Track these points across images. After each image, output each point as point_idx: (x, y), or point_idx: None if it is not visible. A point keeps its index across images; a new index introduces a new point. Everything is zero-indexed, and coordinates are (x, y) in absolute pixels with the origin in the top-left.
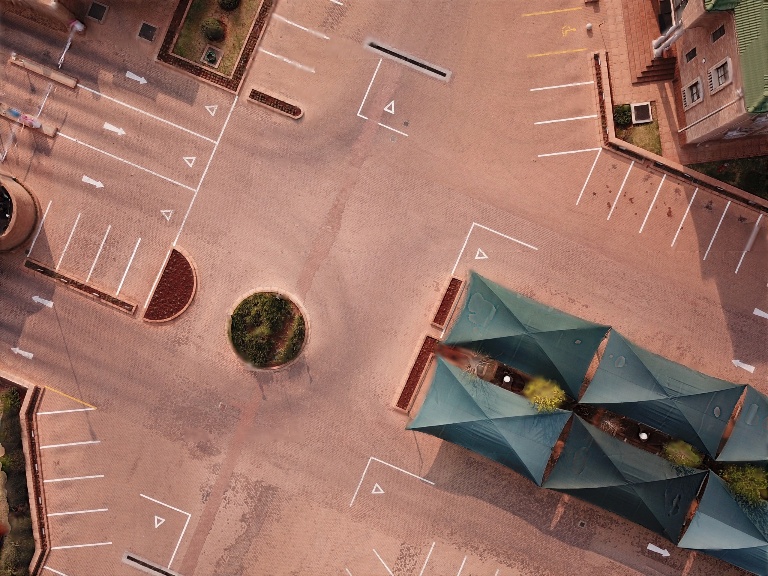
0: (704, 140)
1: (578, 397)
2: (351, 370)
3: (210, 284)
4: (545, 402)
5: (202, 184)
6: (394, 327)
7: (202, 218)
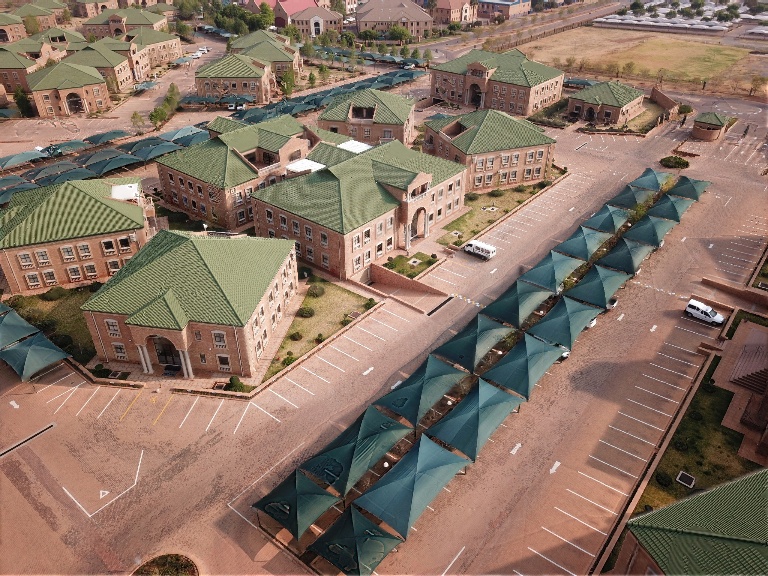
0: None
1: None
2: None
3: None
4: (663, 187)
5: None
6: None
7: None
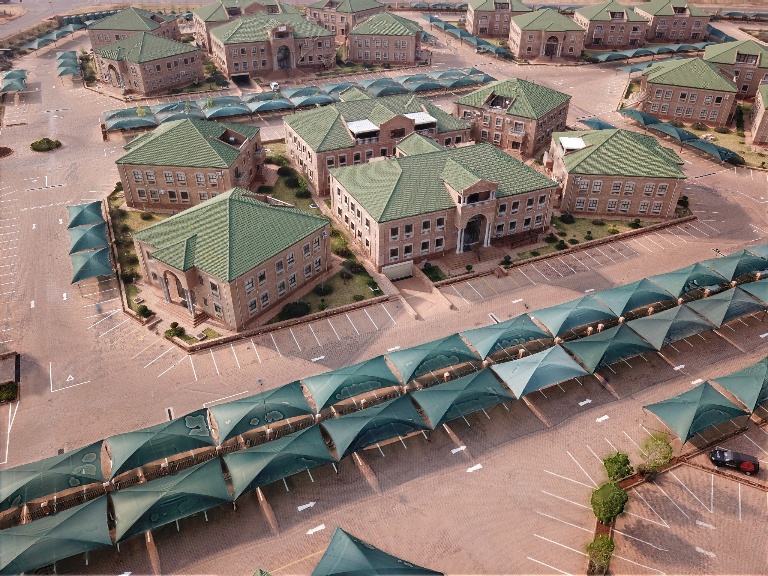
0: (148, 91)
1: (153, 114)
2: (82, 142)
3: (17, 148)
4: None
5: (0, 139)
6: (90, 134)
7: (5, 142)
